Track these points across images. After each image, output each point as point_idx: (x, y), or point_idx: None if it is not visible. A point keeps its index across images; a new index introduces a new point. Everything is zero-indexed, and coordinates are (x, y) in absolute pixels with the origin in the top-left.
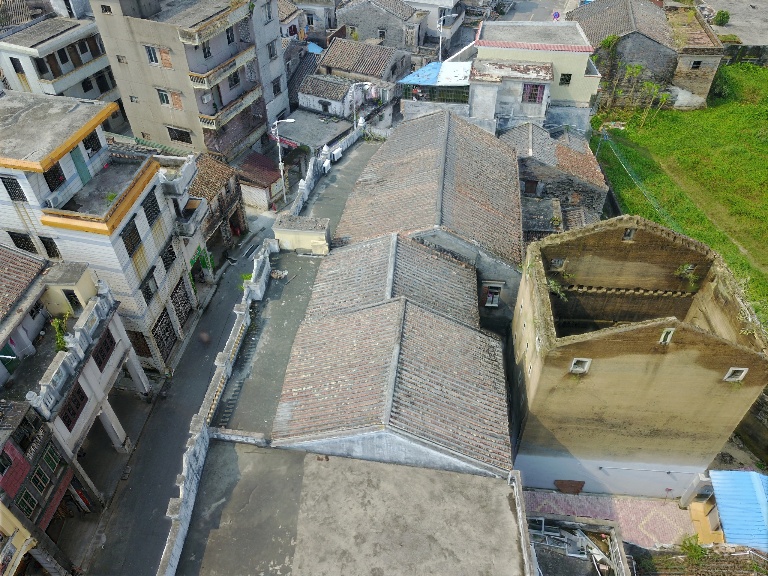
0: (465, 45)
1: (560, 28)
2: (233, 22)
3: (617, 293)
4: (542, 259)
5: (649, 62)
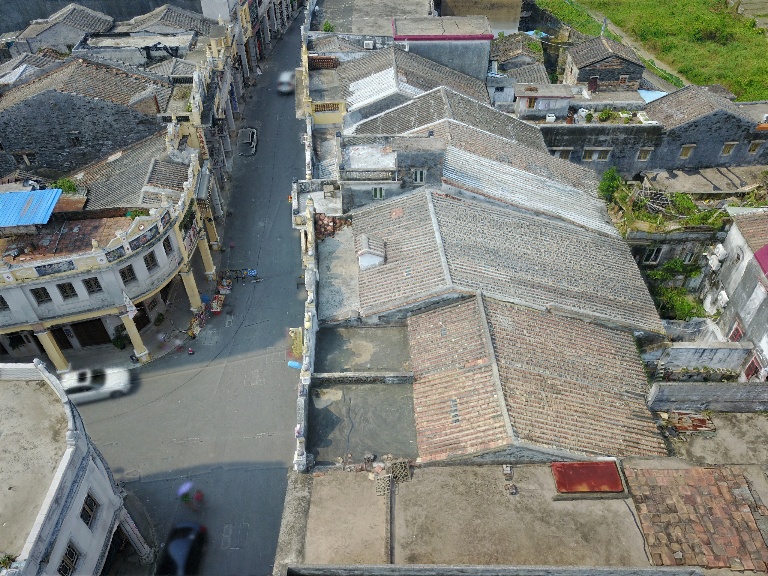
0: None
1: None
2: None
3: None
4: None
5: None
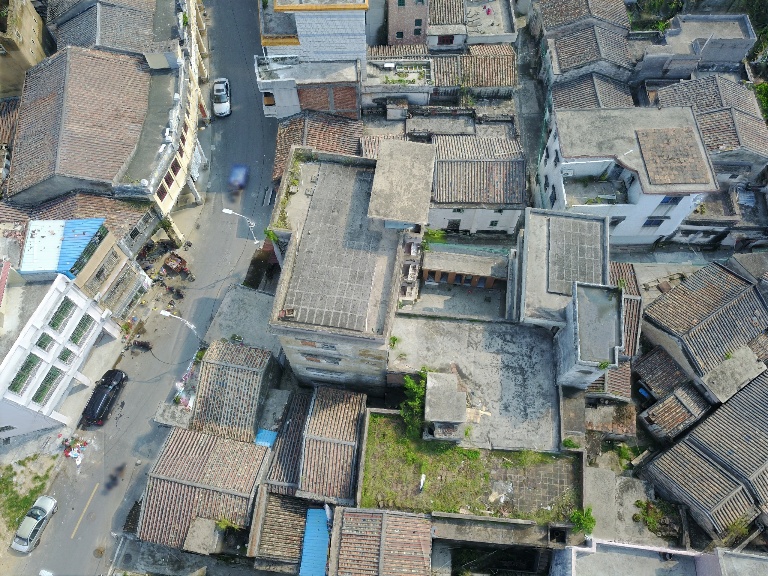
0: None
1: None
2: None
3: None
4: None
5: None
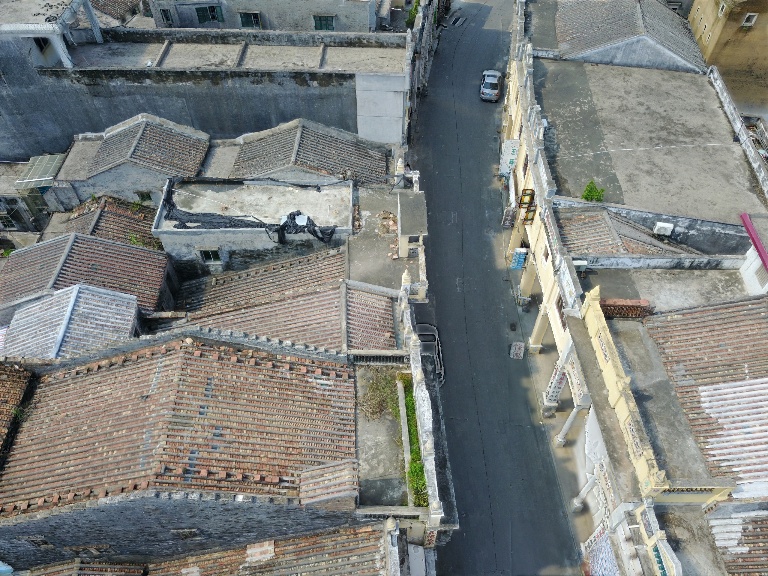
0: None
1: None
2: None
3: None
4: None
5: None
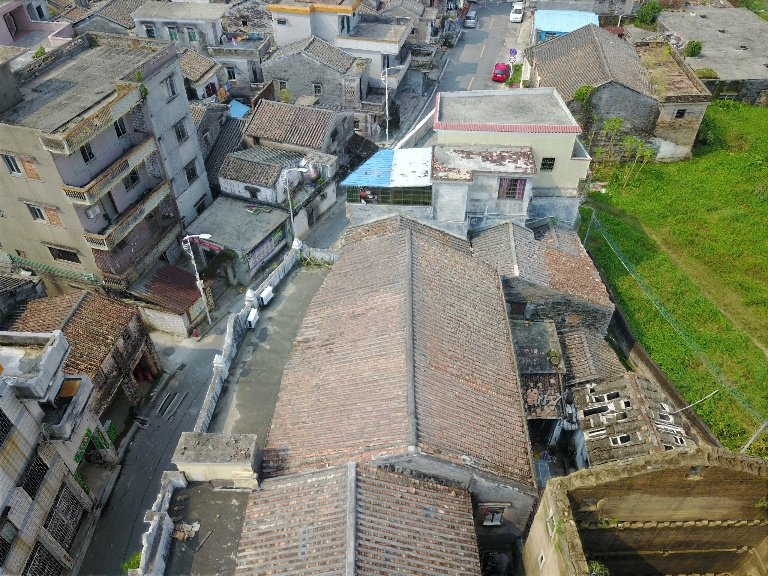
0: (413, 89)
1: (535, 97)
2: (119, 115)
3: (672, 526)
4: (569, 500)
5: (628, 113)
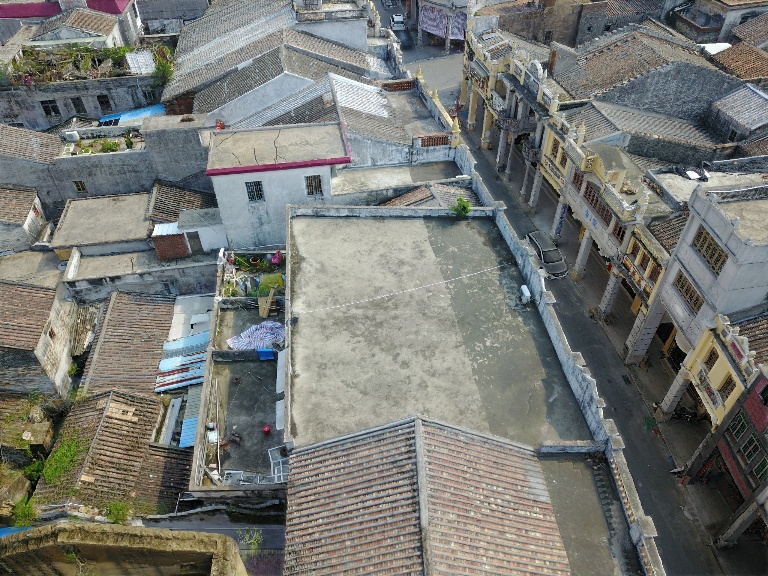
0: None
1: None
2: None
3: None
4: None
5: None
